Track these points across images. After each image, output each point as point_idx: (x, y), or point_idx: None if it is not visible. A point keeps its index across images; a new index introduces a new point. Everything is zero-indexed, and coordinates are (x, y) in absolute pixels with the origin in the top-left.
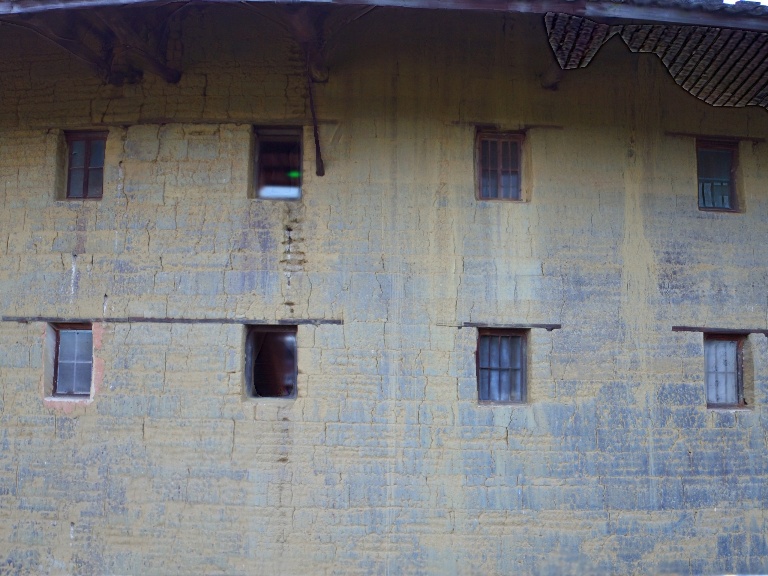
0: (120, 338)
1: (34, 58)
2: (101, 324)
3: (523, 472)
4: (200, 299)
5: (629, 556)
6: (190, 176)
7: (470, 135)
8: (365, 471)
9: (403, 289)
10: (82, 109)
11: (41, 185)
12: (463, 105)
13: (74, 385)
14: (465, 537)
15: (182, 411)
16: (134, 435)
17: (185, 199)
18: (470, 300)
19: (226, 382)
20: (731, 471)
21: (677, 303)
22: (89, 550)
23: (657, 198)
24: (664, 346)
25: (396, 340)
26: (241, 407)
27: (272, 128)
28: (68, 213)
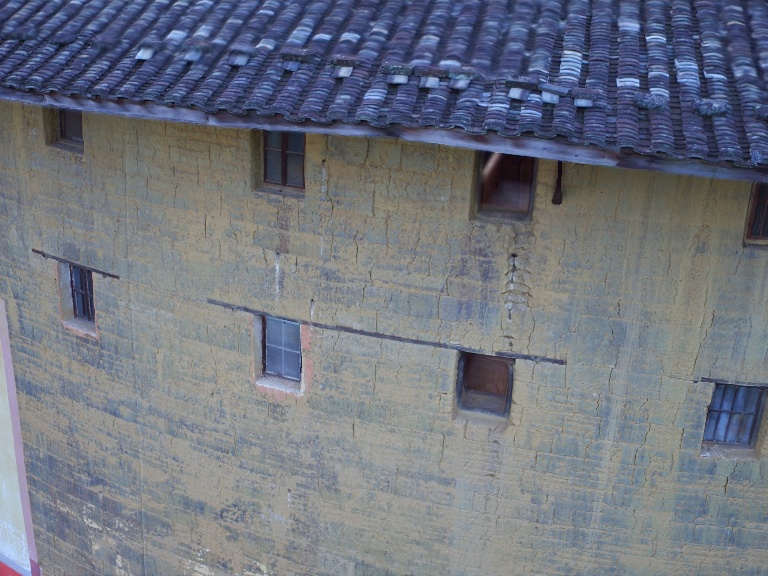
0: (329, 344)
1: None
2: (309, 327)
3: (736, 516)
4: (412, 320)
5: None
6: (403, 188)
7: None
8: (572, 497)
9: (638, 338)
10: None
11: (236, 170)
12: None
13: (283, 369)
14: (665, 561)
15: (392, 419)
16: (345, 432)
17: (397, 213)
18: (713, 356)
19: (437, 401)
20: None
21: None
22: (305, 514)
23: None
24: None
25: (622, 387)
26: (451, 425)
27: None
28: (268, 207)
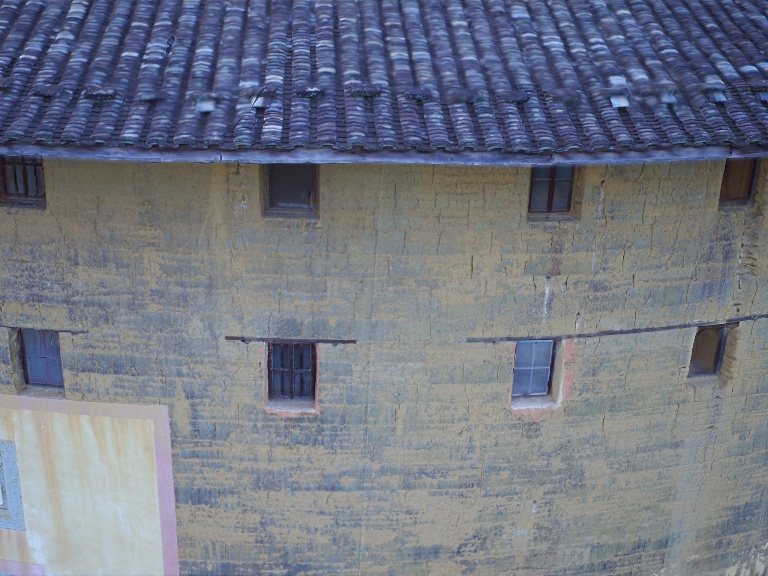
0: (591, 351)
1: None
2: (573, 340)
3: None
4: (666, 310)
5: None
6: (670, 194)
7: None
8: (767, 425)
9: None
10: None
11: (512, 205)
12: None
13: (530, 388)
14: None
15: (638, 404)
16: (595, 428)
17: (663, 217)
18: None
19: (677, 376)
20: None
21: None
22: (549, 519)
23: None
24: None
25: None
26: (686, 394)
27: None
28: (543, 235)
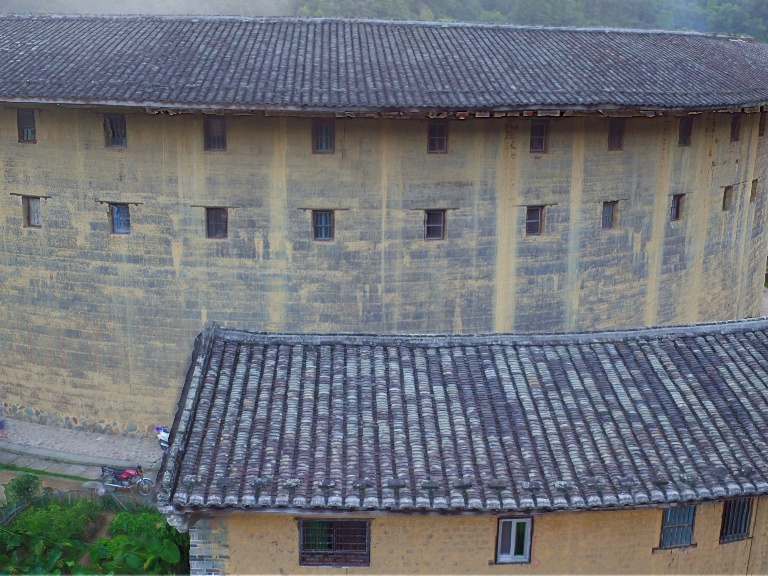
0: None
1: None
2: None
3: None
4: None
5: (1, 281)
6: None
7: None
8: None
9: None
10: None
11: None
12: None
13: None
14: None
15: None
16: None
17: None
18: None
19: None
20: (34, 254)
21: (11, 183)
22: None
23: (3, 137)
24: (7, 201)
25: None
26: None
27: None
28: None
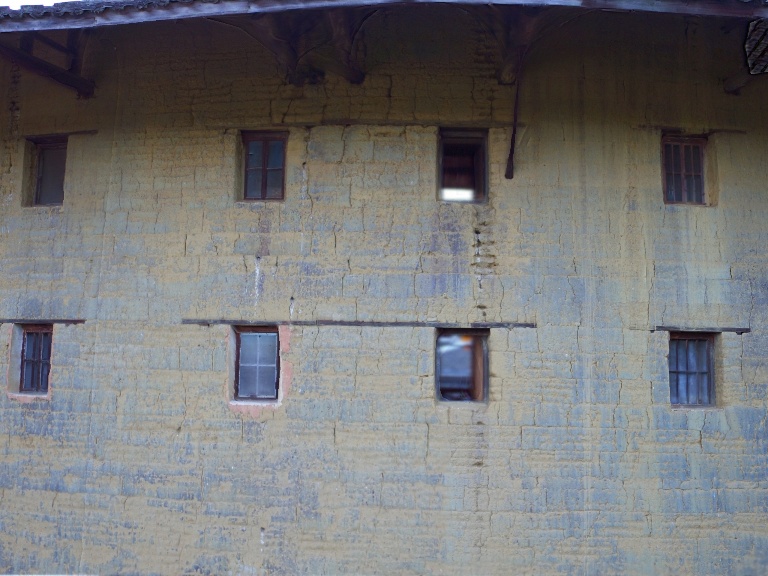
0: (308, 341)
1: (208, 57)
2: (288, 327)
3: (717, 475)
4: (390, 302)
5: None
6: (377, 178)
7: (657, 139)
8: (562, 475)
9: (595, 293)
10: (262, 109)
11: (220, 186)
12: (649, 109)
13: (257, 389)
14: (662, 540)
15: (374, 415)
16: (325, 439)
17: (372, 201)
18: (662, 304)
19: (419, 386)
20: None
21: None
22: (281, 555)
23: None
24: None
25: (590, 344)
26: (435, 411)
27: (457, 130)
28: (250, 214)
